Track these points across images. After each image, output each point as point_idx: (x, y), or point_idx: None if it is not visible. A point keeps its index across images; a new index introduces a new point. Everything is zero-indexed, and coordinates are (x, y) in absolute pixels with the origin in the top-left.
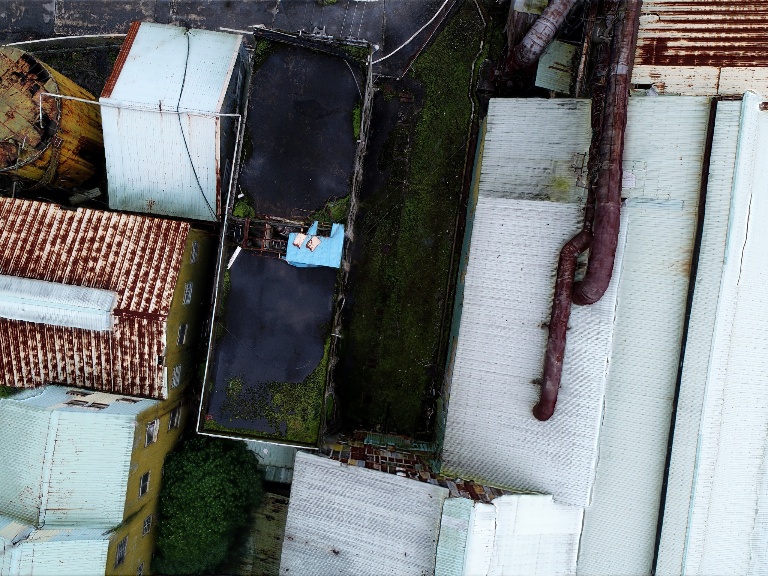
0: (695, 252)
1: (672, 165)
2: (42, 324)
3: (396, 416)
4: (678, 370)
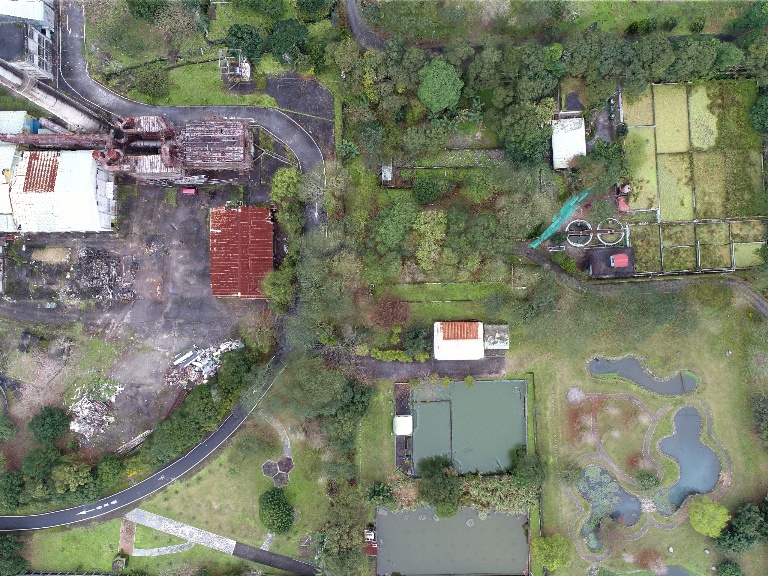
0: None
1: None
2: None
3: None
4: None
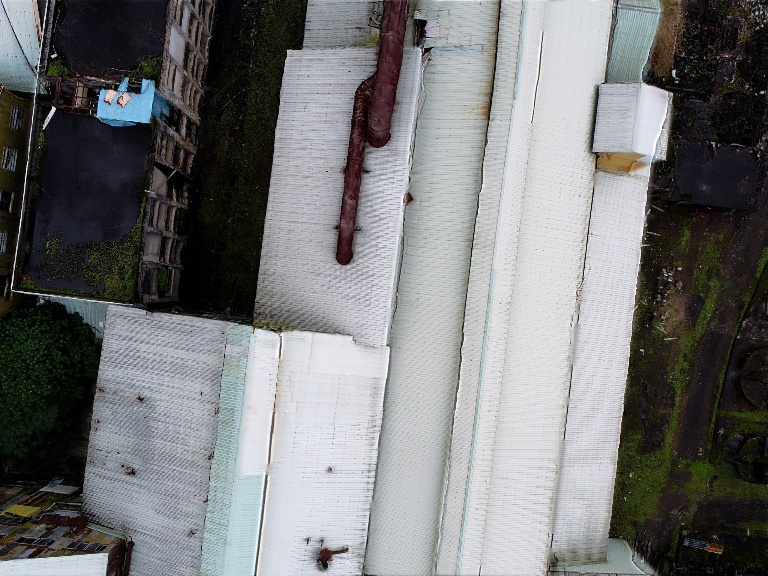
0: (491, 93)
1: (472, 10)
2: None
3: (246, 299)
4: (476, 211)
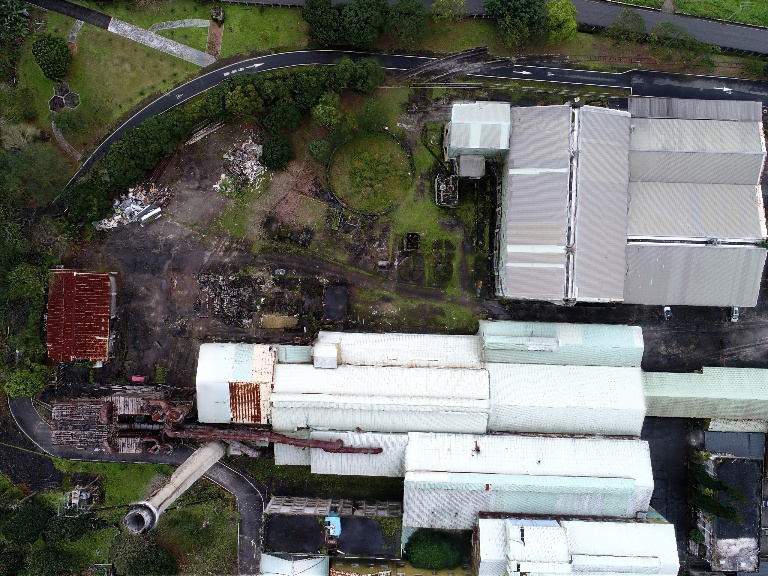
0: None
1: (295, 414)
2: None
3: None
4: None
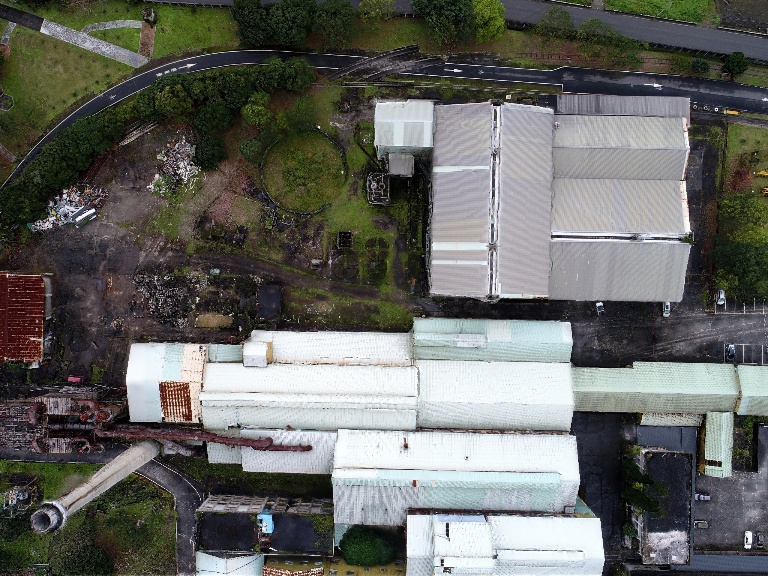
0: None
1: (225, 413)
2: None
3: None
4: None
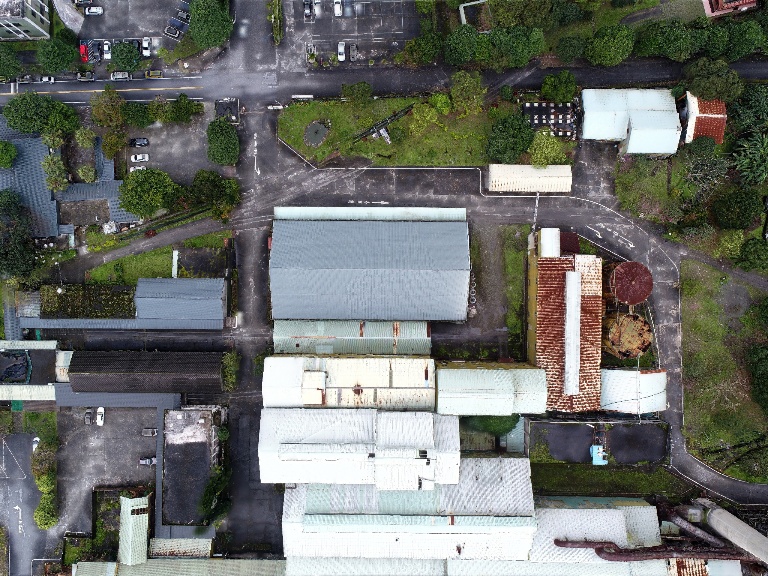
0: None
1: (644, 575)
2: (563, 369)
3: None
4: None
